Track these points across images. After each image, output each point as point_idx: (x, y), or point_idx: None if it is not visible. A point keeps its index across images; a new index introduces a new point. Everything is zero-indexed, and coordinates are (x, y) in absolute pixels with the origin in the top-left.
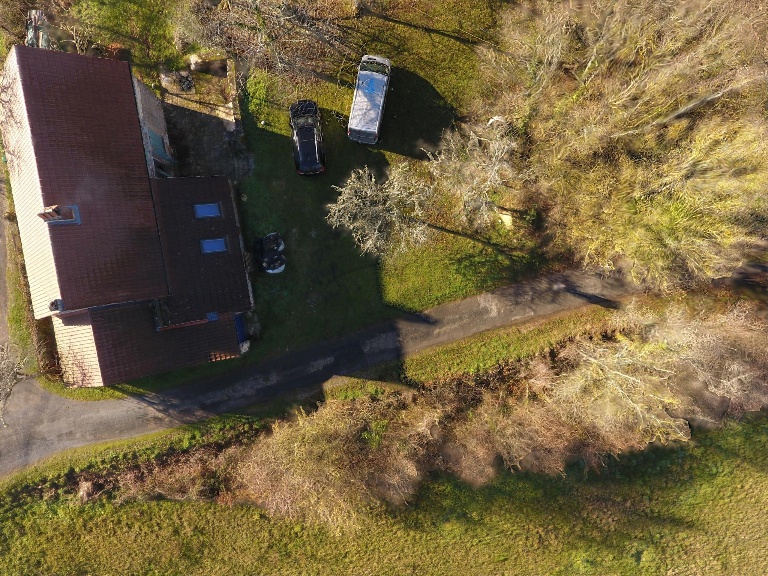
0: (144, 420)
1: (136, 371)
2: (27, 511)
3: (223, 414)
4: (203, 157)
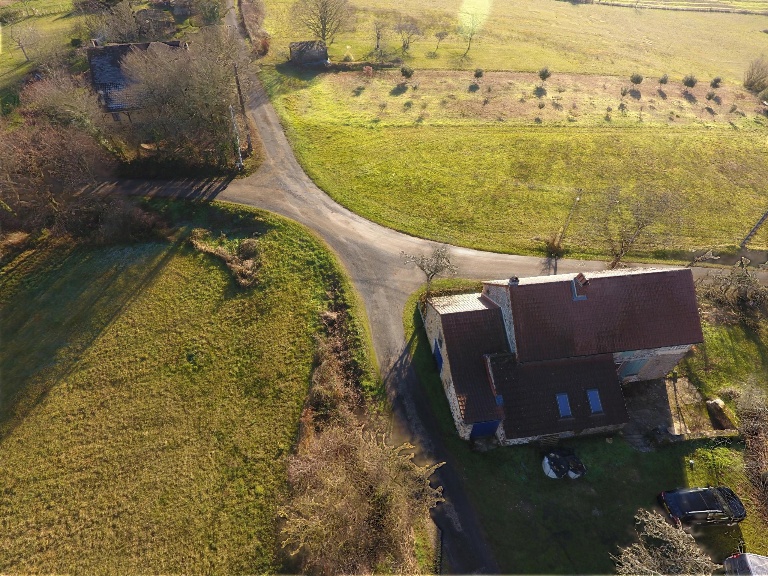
0: (388, 354)
1: (451, 337)
2: (318, 283)
3: (394, 414)
4: (630, 409)
